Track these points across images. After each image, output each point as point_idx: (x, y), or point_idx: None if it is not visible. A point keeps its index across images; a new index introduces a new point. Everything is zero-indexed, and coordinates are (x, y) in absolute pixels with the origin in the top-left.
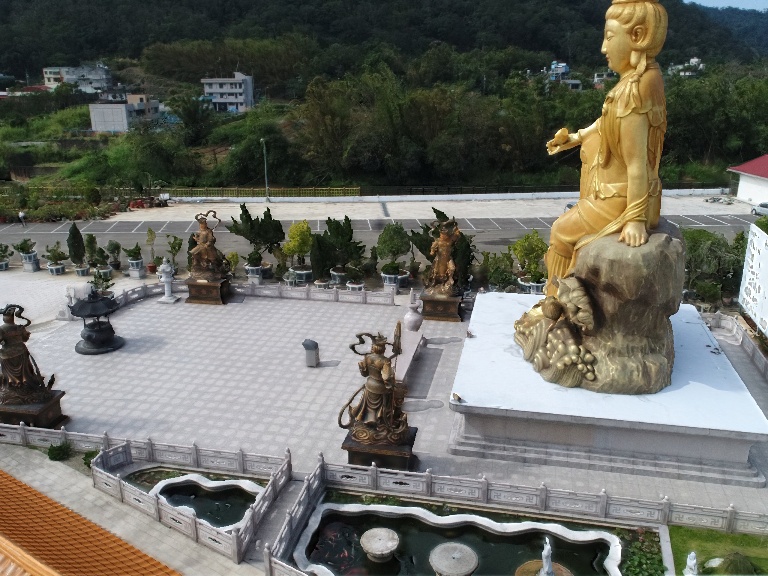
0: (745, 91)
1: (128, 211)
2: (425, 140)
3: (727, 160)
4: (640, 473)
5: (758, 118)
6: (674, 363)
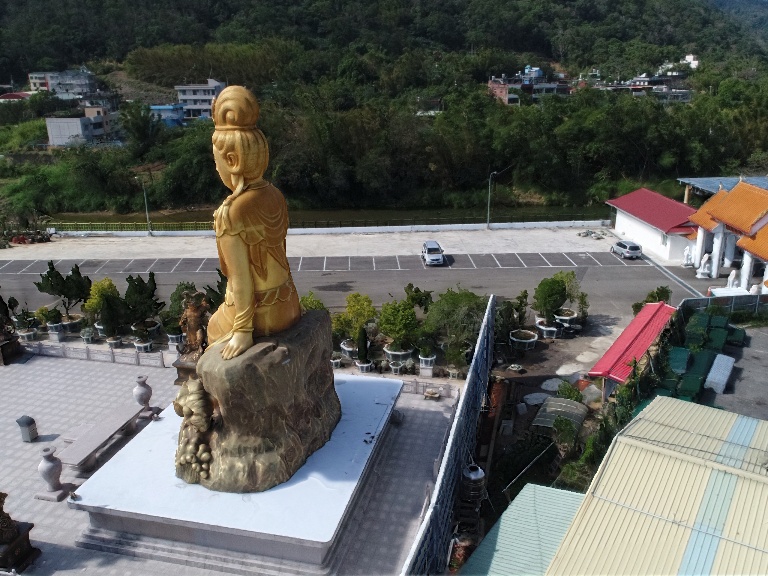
0: (679, 107)
1: (7, 247)
2: (355, 159)
3: (662, 176)
4: (228, 571)
5: (693, 134)
6: (316, 454)
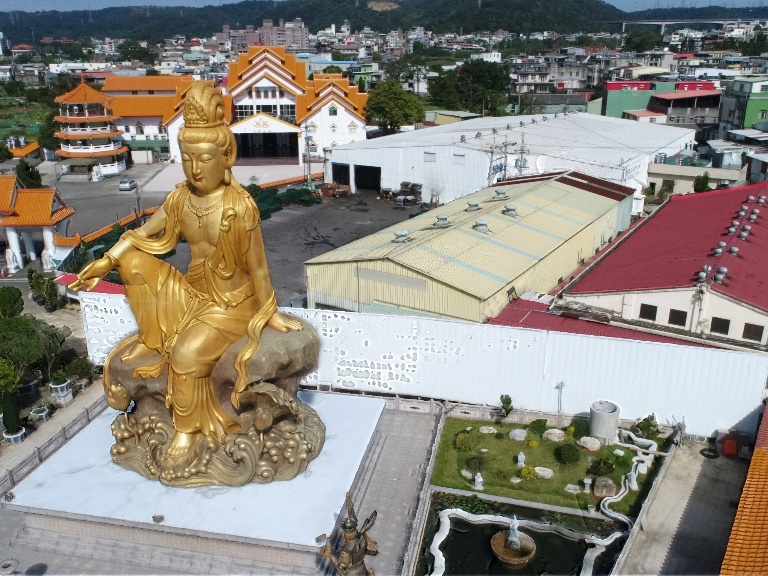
0: None
1: None
2: None
3: None
4: None
5: None
6: None
